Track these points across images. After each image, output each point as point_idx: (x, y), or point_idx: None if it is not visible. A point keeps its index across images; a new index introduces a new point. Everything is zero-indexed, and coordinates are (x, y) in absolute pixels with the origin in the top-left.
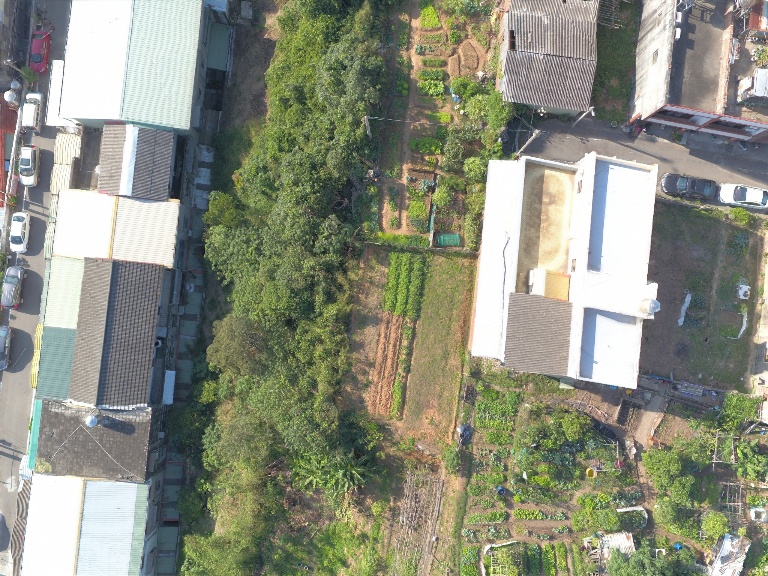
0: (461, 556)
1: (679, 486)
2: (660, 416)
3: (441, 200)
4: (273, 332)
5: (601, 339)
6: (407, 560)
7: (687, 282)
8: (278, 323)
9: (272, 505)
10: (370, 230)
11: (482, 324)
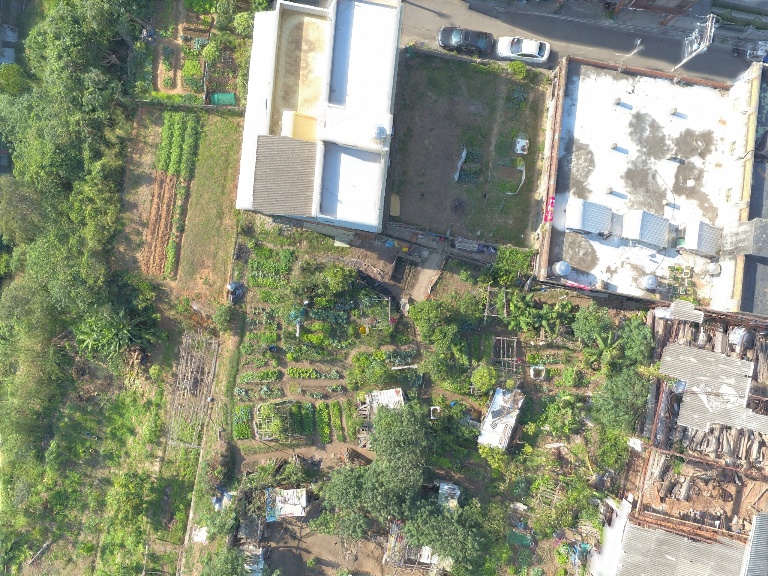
0: (233, 415)
1: (439, 334)
2: (437, 274)
3: (209, 55)
4: (46, 193)
5: (346, 178)
6: (190, 426)
7: (464, 137)
8: (51, 184)
9: (52, 370)
10: (144, 90)
11: (245, 176)
